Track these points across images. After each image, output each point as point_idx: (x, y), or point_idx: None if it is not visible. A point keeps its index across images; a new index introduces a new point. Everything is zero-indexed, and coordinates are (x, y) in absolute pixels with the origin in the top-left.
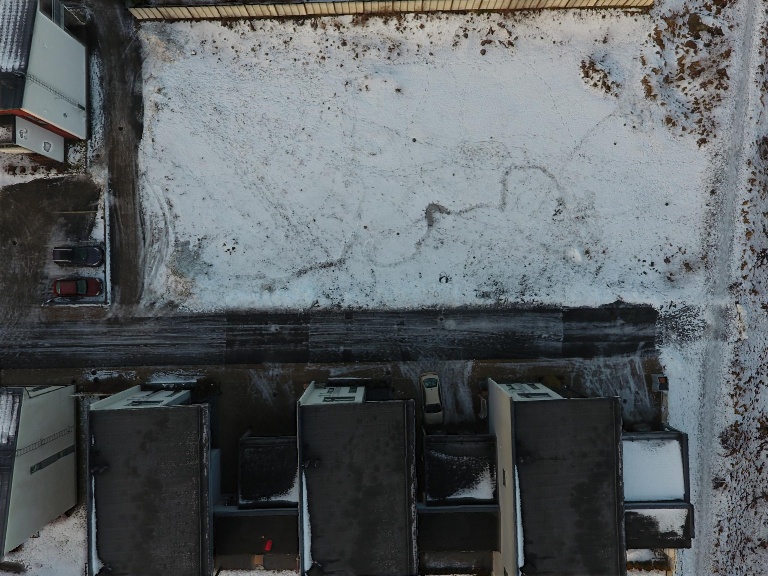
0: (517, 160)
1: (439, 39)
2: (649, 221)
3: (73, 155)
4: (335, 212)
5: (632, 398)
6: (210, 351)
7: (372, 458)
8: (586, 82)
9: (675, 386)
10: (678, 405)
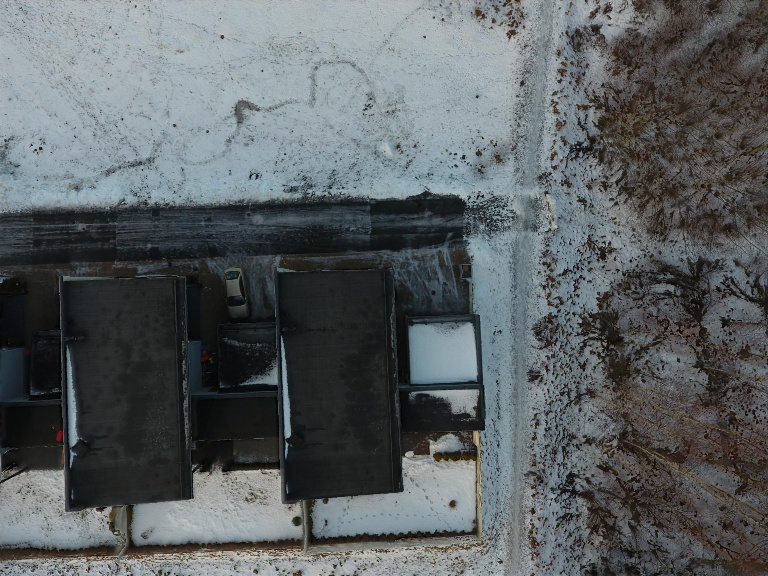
0: (326, 55)
1: None
2: (460, 114)
3: None
4: (143, 110)
5: (440, 289)
6: (17, 252)
7: (141, 334)
8: None
9: (484, 277)
10: (488, 296)
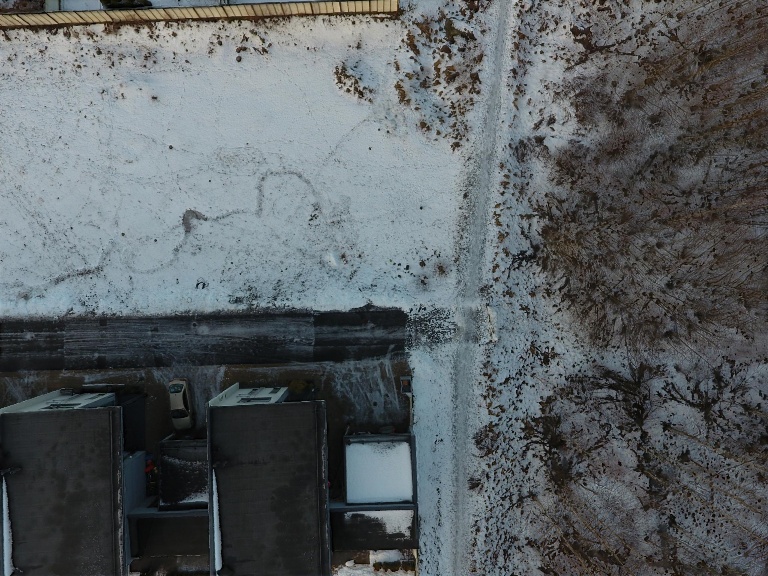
0: (273, 166)
1: (194, 47)
2: (404, 225)
3: None
4: (92, 220)
5: (382, 401)
6: None
7: (77, 465)
8: (340, 88)
9: (425, 388)
10: (430, 407)
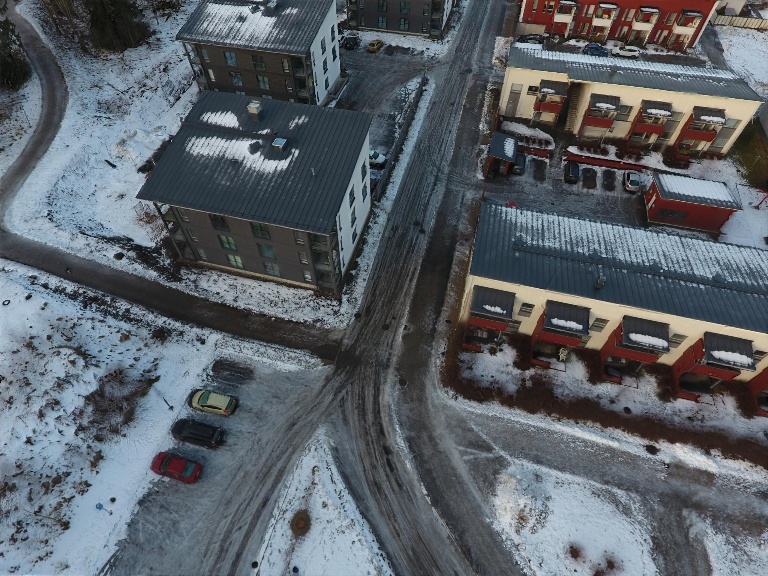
0: None
1: None
2: None
3: (689, 50)
4: None
5: None
6: None
7: None
8: None
9: None
10: None
